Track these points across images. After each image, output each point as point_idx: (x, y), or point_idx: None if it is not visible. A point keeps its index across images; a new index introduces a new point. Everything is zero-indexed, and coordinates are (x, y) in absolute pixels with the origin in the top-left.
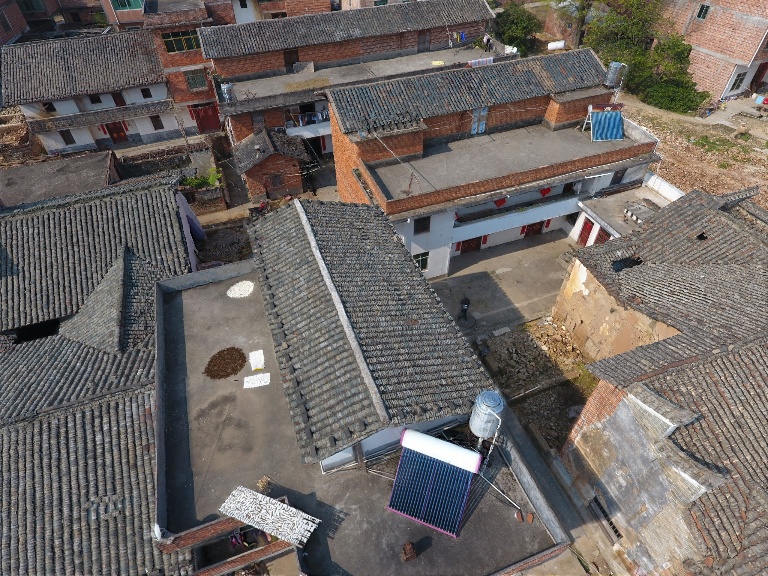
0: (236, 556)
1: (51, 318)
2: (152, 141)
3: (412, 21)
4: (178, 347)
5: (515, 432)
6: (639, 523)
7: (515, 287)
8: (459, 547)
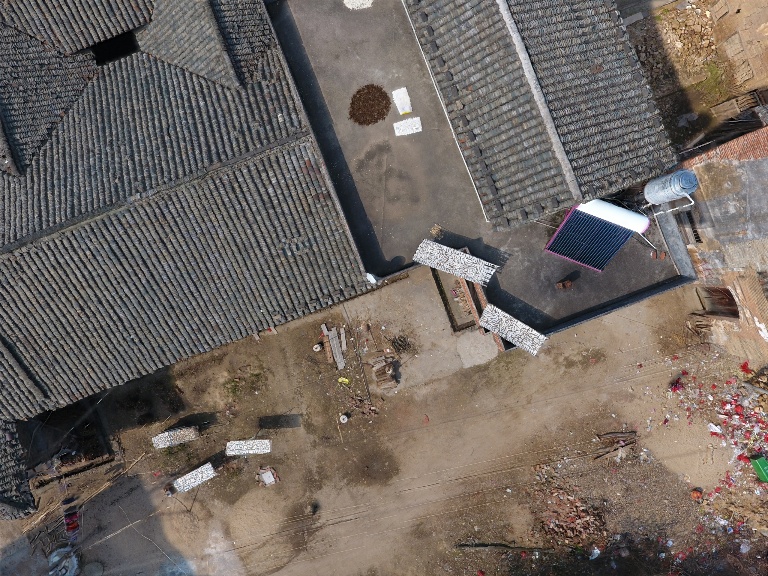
0: None
1: (125, 30)
2: None
3: None
4: (311, 85)
5: None
6: (729, 239)
7: None
8: (602, 278)
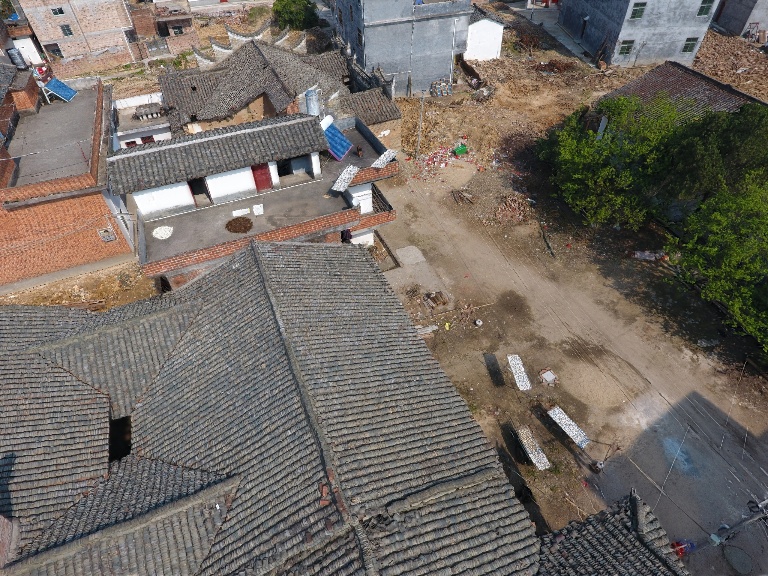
0: None
1: (108, 415)
2: None
3: None
4: None
5: None
6: None
7: None
8: None
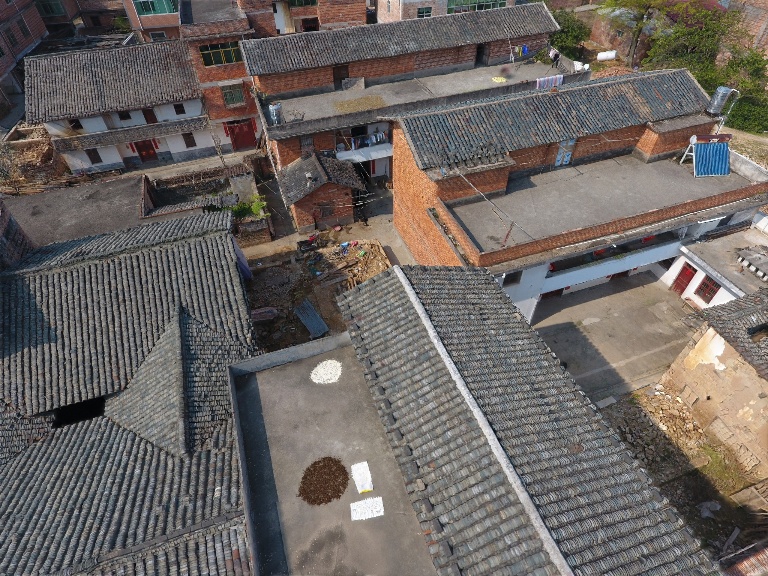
0: None
1: (96, 396)
2: (183, 159)
3: (471, 33)
4: (261, 455)
5: None
6: None
7: (607, 342)
8: None
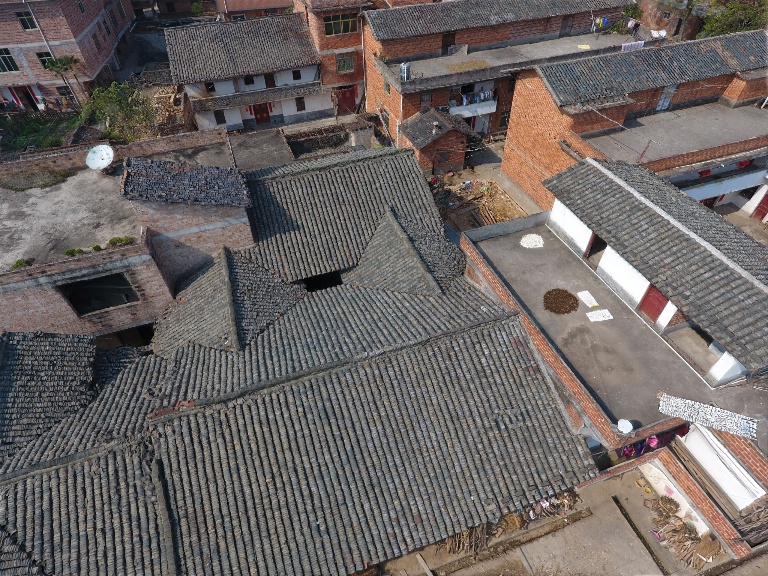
0: (614, 466)
1: (337, 269)
2: (292, 122)
3: (559, 6)
4: None
5: None
6: None
7: None
8: None
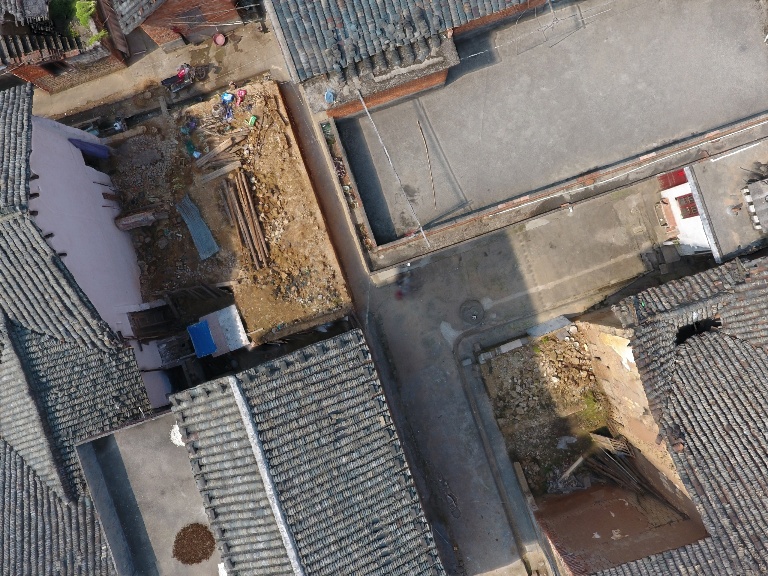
0: None
1: None
2: None
3: None
4: (135, 521)
5: (499, 457)
6: None
7: (545, 256)
8: None
